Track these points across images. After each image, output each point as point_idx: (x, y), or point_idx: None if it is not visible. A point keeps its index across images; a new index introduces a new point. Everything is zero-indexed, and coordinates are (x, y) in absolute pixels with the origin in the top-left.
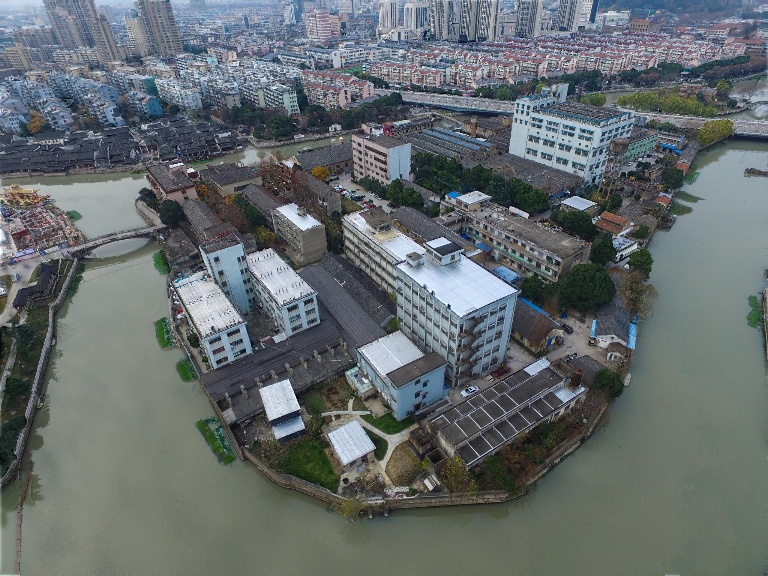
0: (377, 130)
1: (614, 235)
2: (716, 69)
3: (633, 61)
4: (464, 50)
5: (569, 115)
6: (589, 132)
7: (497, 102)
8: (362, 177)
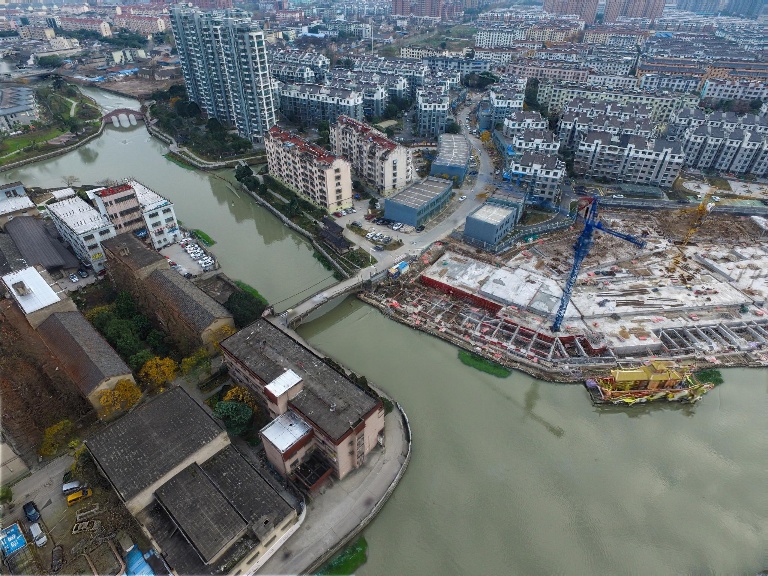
0: None
1: None
2: None
3: None
4: None
5: None
6: None
7: None
8: None
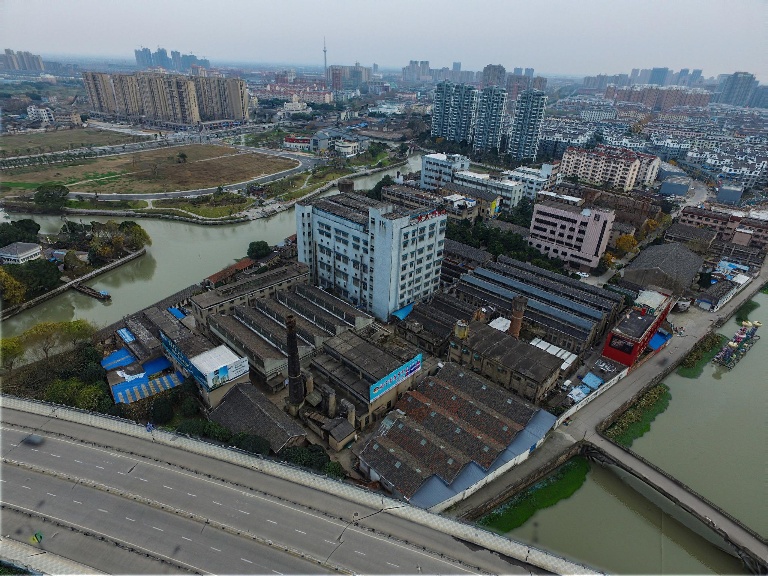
0: None
1: None
2: None
3: None
4: None
5: None
6: None
7: None
8: None
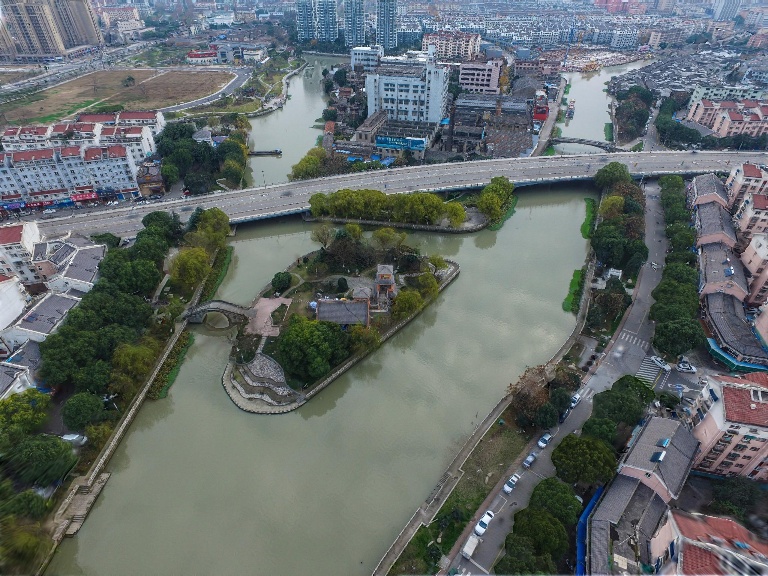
0: None
1: None
2: None
3: None
4: None
5: None
6: None
7: None
8: None
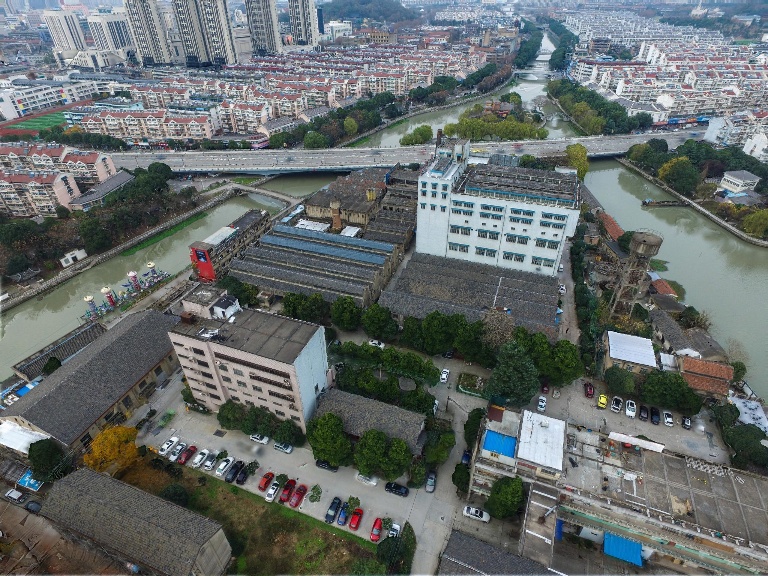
0: (227, 308)
1: (728, 400)
2: (486, 80)
3: (410, 77)
4: (215, 79)
5: (518, 194)
6: (558, 217)
7: (311, 153)
8: (218, 402)
